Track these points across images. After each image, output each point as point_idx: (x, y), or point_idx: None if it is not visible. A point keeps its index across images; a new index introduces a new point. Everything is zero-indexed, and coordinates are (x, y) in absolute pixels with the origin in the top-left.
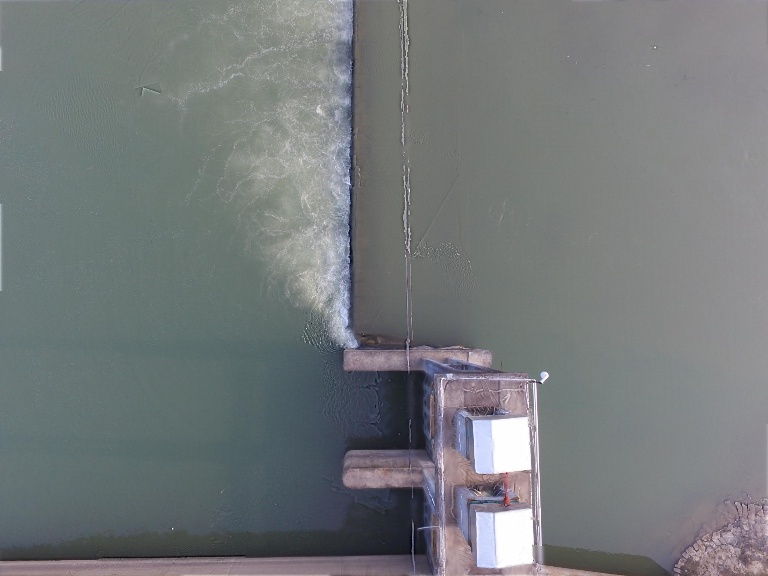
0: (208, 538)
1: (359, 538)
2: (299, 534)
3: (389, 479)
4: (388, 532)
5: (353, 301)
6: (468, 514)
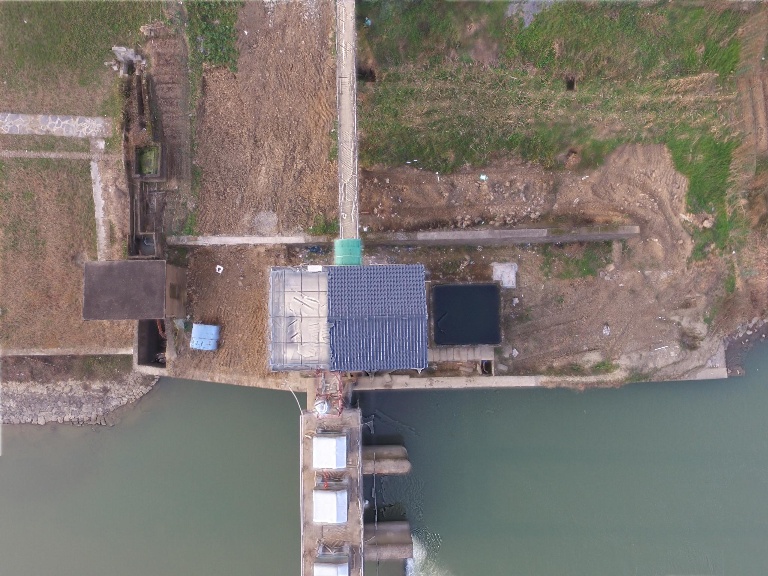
0: (501, 392)
1: (394, 393)
2: (437, 396)
3: (378, 466)
4: (373, 398)
5: (404, 574)
6: (349, 573)
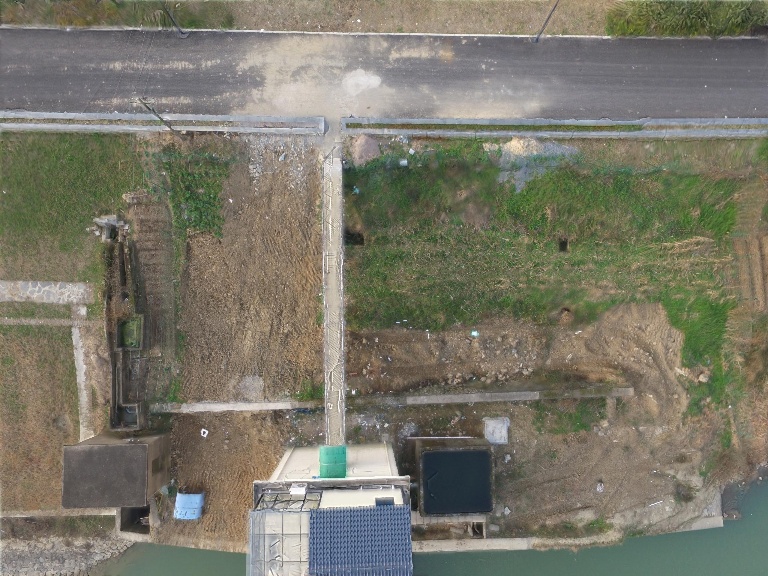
0: None
1: None
2: None
3: None
4: None
5: None
6: None
